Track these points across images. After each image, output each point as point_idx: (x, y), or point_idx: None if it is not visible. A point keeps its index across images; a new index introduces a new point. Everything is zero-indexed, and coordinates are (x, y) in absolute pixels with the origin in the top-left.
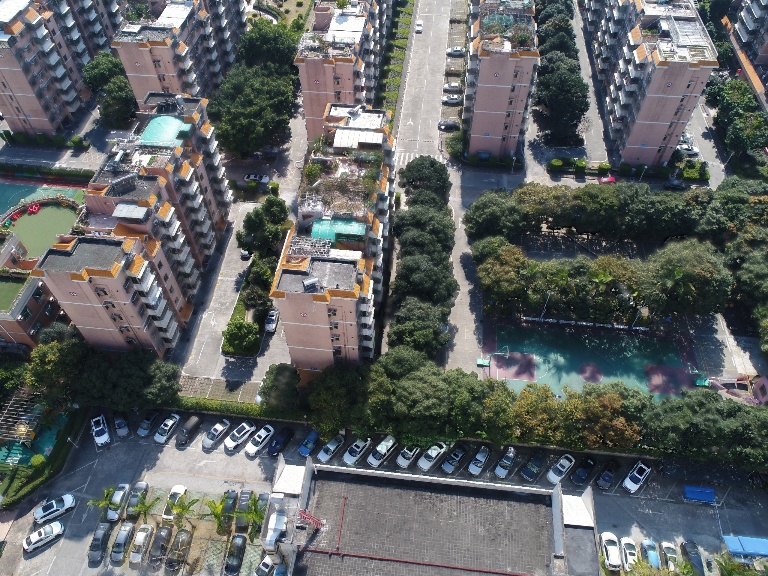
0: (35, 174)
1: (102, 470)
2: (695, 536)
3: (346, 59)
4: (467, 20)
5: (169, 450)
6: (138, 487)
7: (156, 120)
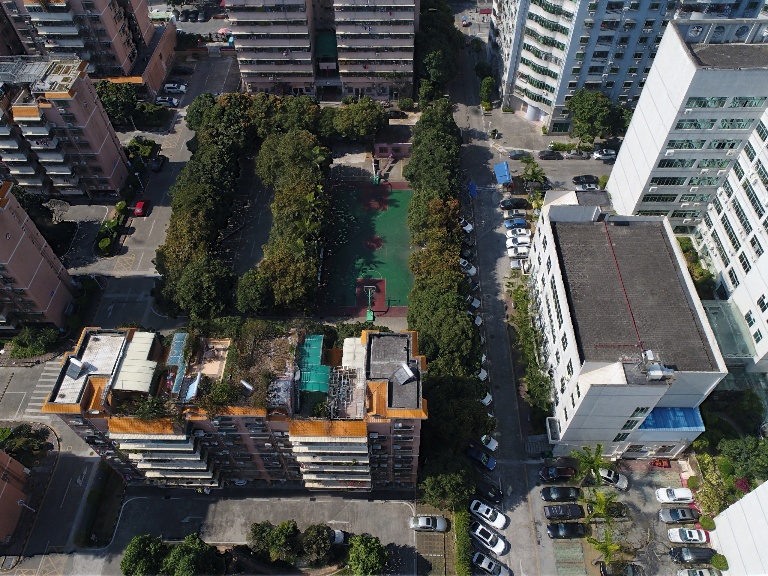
0: None
1: None
2: (494, 203)
3: None
4: None
5: None
6: None
7: None
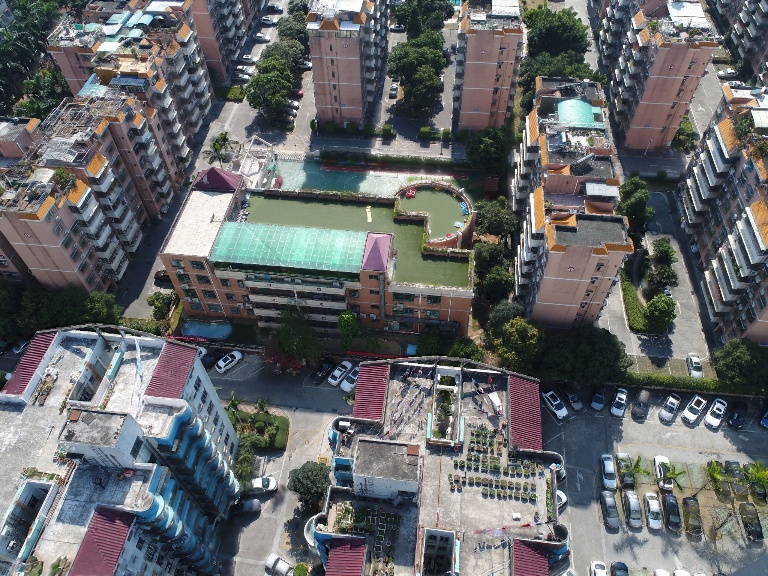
0: (359, 161)
1: (573, 442)
2: None
3: (712, 43)
4: (719, 8)
5: (628, 423)
6: (623, 458)
7: (566, 103)
